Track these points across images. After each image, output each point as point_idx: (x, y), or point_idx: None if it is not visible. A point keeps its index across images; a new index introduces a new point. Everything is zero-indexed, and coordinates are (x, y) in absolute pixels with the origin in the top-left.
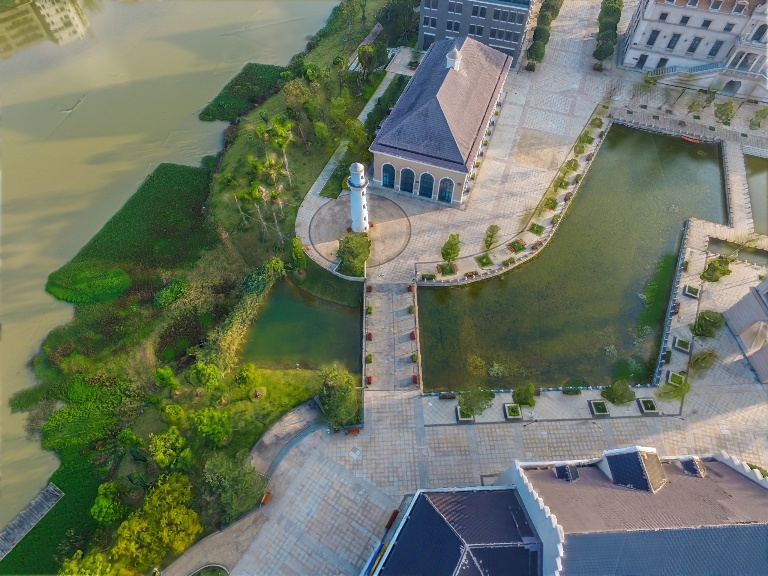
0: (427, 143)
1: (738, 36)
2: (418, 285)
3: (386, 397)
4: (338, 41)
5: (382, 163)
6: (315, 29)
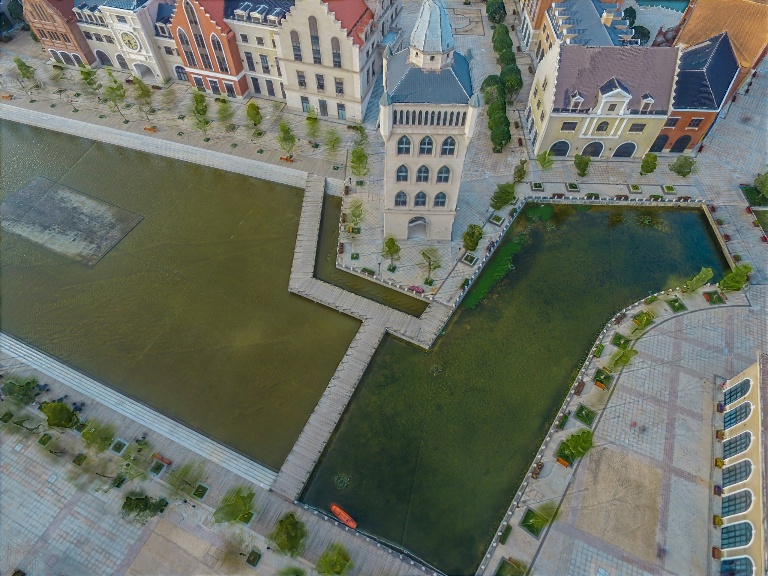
0: None
1: None
2: None
3: (730, 202)
4: None
5: None
6: None
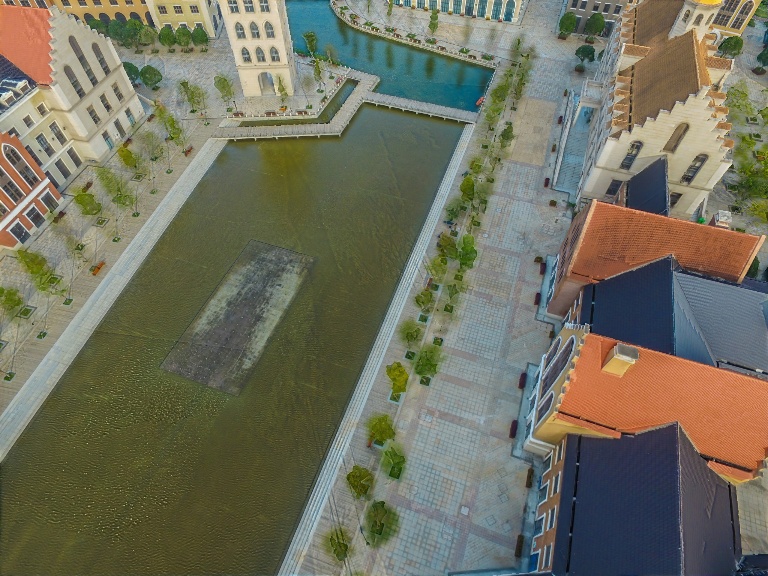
0: None
1: None
2: None
3: None
4: None
5: None
6: None
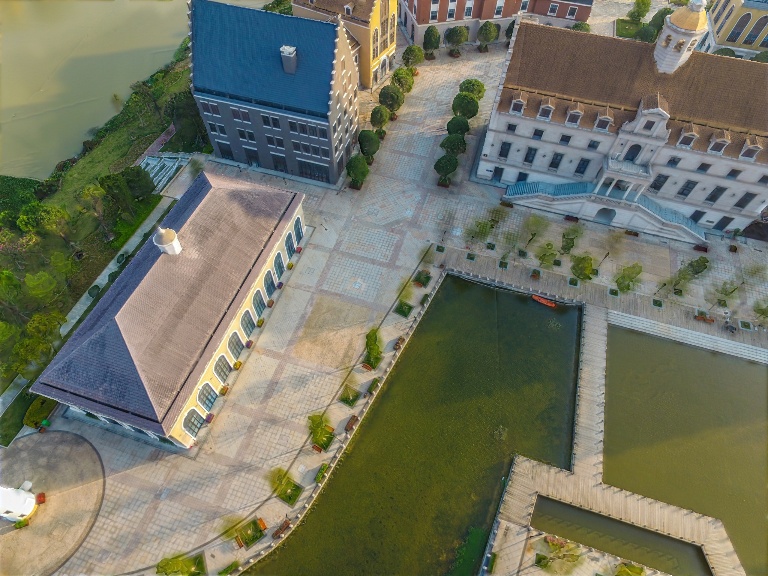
0: (106, 387)
1: (606, 155)
2: None
3: None
4: (124, 139)
5: None
6: (106, 117)
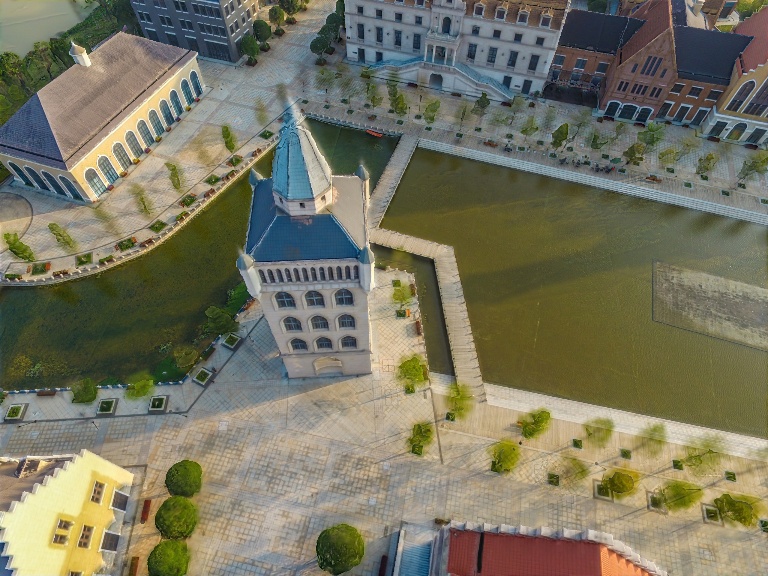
0: (31, 140)
1: (429, 29)
2: (5, 285)
3: None
4: (82, 37)
5: (6, 161)
6: (71, 25)
